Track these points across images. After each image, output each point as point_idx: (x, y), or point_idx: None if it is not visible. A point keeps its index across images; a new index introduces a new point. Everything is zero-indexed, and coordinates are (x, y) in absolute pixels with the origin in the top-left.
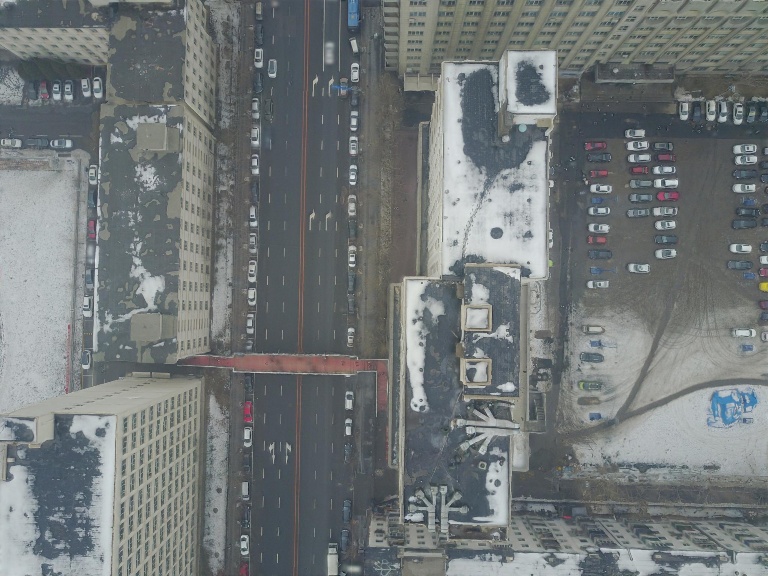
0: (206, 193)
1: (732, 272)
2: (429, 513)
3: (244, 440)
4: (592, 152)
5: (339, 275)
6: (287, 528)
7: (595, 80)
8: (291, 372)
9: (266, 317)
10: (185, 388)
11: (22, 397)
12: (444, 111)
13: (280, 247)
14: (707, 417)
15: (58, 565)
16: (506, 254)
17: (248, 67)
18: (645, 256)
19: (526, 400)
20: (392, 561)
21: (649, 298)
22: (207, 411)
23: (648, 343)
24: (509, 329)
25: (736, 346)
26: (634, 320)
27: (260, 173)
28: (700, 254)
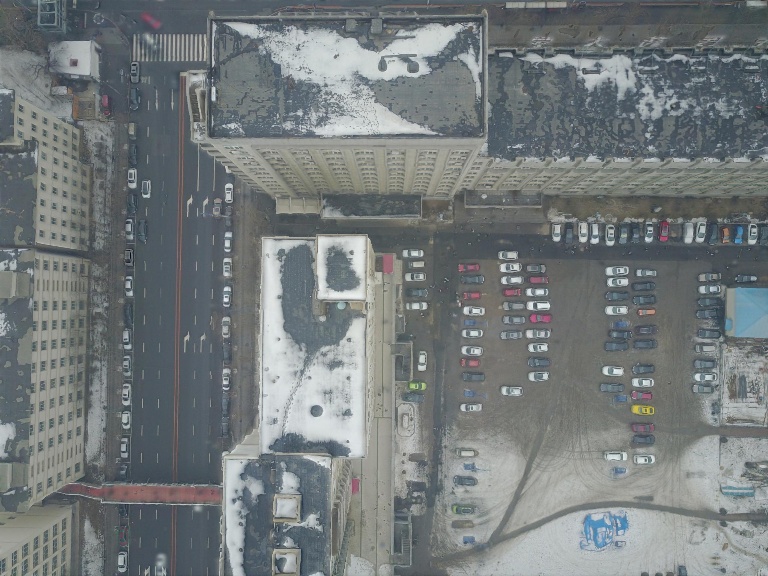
0: (76, 319)
1: (605, 394)
2: None
3: (118, 566)
4: (465, 274)
5: (214, 398)
6: None
7: (464, 205)
8: (160, 502)
9: (141, 440)
10: (46, 527)
11: None
12: (264, 288)
13: (155, 369)
14: (580, 540)
15: None
16: (326, 433)
17: (122, 187)
18: (519, 378)
19: (390, 534)
20: None
21: (522, 420)
22: (82, 536)
23: (521, 466)
24: (319, 518)
25: (609, 469)
26: (508, 443)
27: (135, 294)
28: (573, 376)
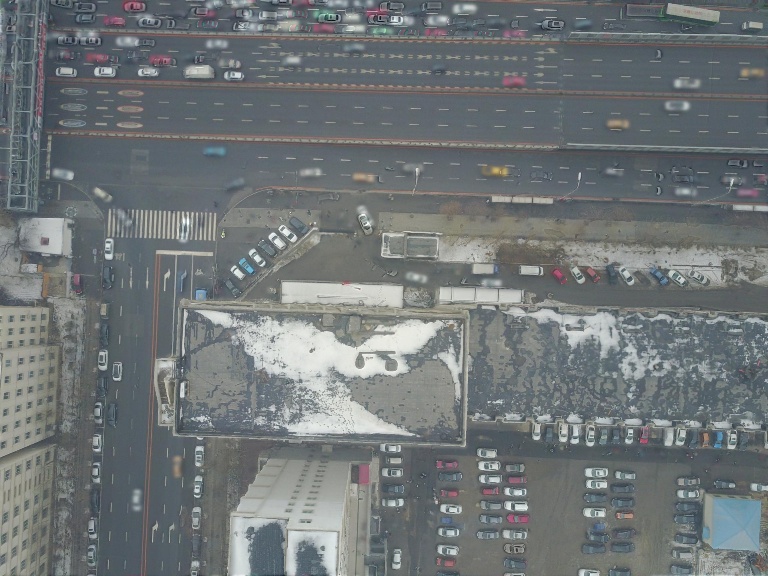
0: (39, 512)
1: None
2: None
3: None
4: (443, 470)
5: None
6: None
7: None
8: None
9: None
10: None
11: None
12: (231, 568)
13: (121, 559)
14: None
15: None
16: None
17: (92, 368)
18: None
19: None
20: None
21: None
22: None
23: None
24: None
25: None
26: None
27: (102, 480)
28: None
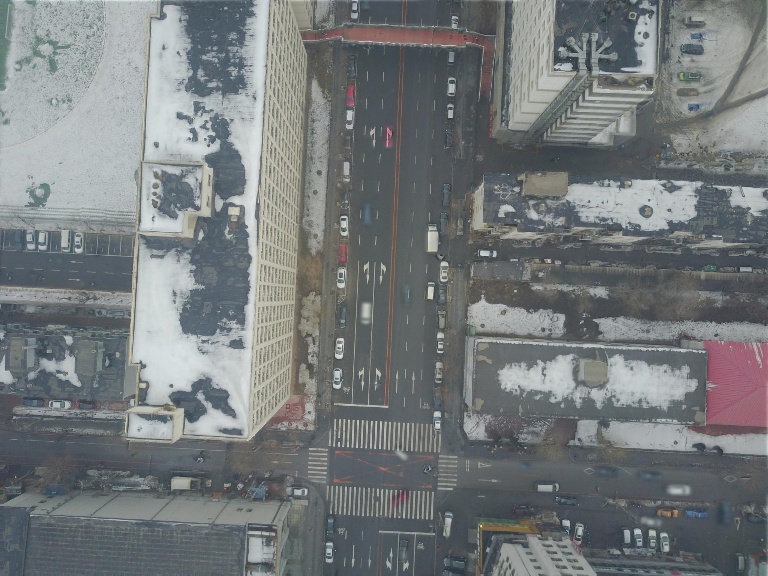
0: None
1: None
2: (579, 59)
3: (346, 122)
4: None
5: None
6: (386, 212)
7: None
8: (400, 43)
9: (370, 4)
10: None
11: (123, 77)
12: None
13: None
14: None
15: (210, 103)
16: None
17: None
18: None
19: None
20: (512, 185)
21: None
22: (309, 95)
23: (748, 37)
24: None
25: None
26: (735, 14)
27: None
28: None
